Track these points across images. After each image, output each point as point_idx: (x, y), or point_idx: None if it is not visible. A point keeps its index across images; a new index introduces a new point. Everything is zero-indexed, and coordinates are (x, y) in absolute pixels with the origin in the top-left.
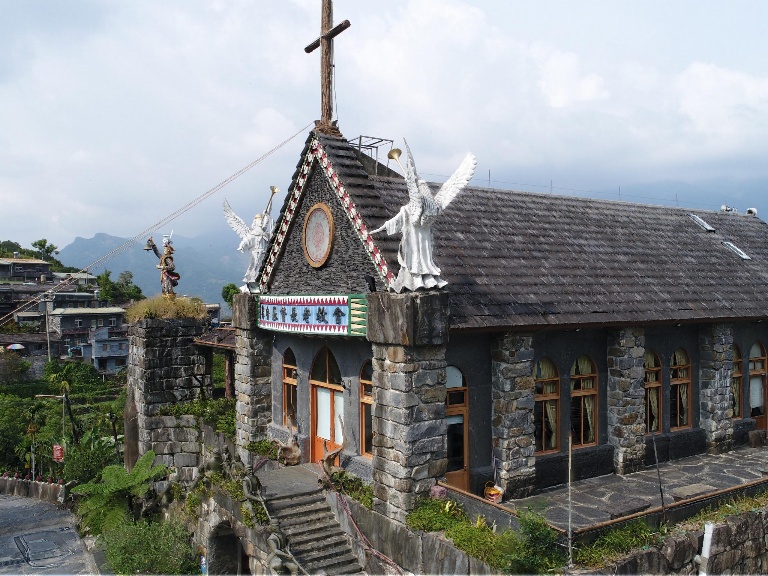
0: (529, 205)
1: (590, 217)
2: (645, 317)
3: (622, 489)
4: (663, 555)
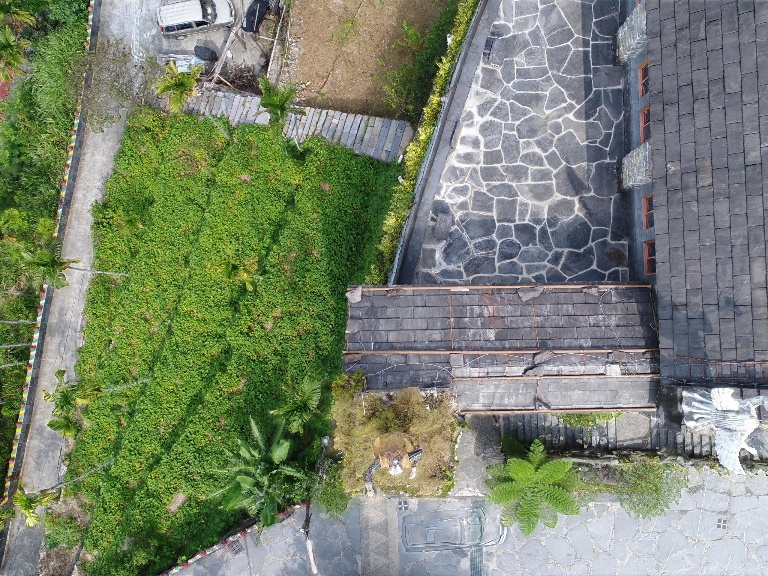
0: None
1: None
2: None
3: None
4: None
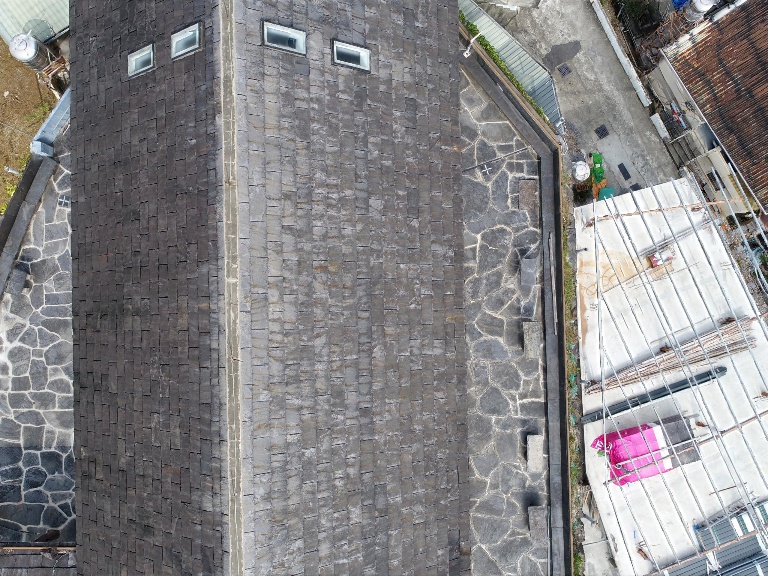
0: (278, 443)
1: (294, 327)
2: (464, 415)
3: (470, 447)
4: (580, 546)
